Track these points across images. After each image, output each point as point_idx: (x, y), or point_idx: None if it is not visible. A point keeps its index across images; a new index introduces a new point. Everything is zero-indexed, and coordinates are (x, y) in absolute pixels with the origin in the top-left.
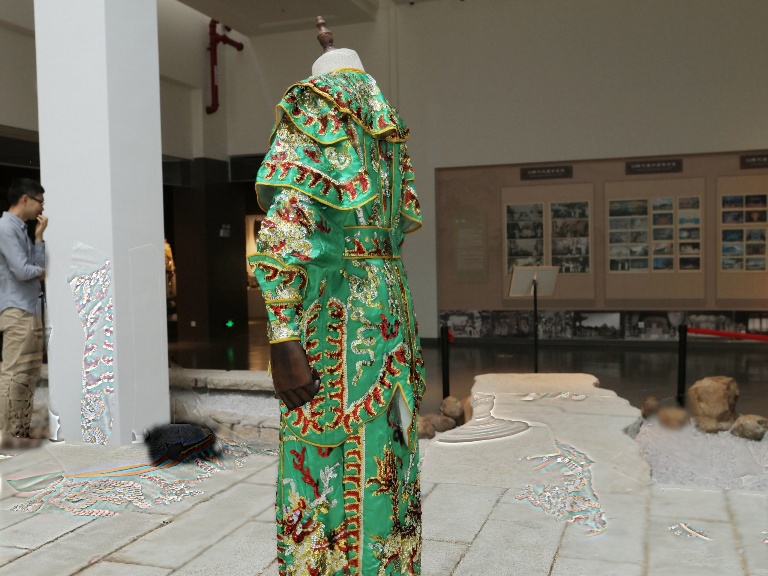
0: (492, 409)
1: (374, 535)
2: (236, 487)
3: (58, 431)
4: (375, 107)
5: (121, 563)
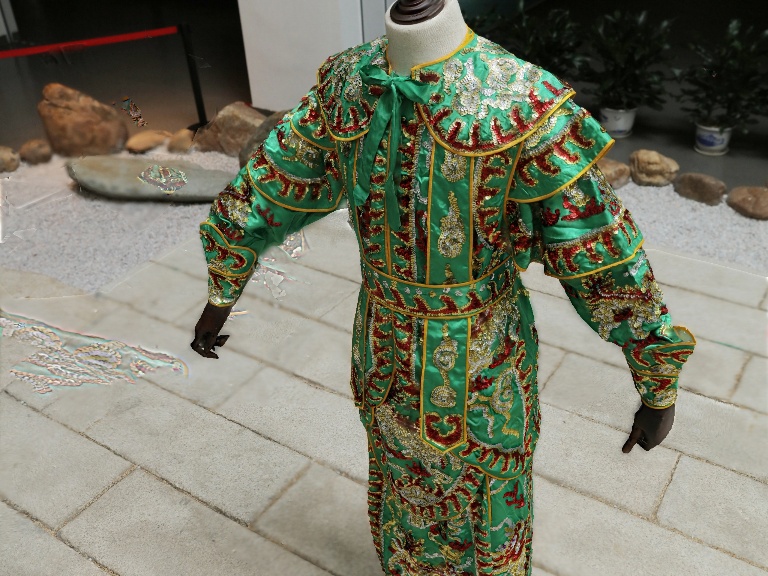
0: None
1: None
2: None
3: None
4: None
5: None
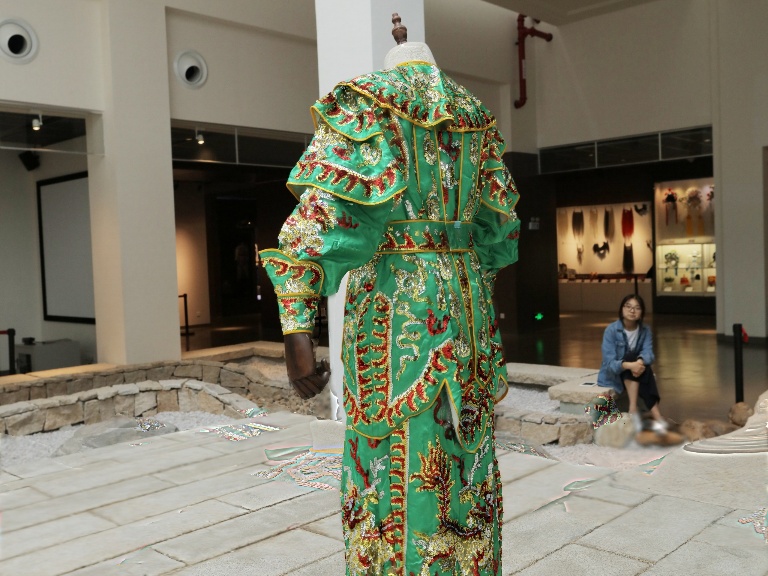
0: None
1: (417, 531)
2: None
3: (338, 410)
4: (434, 98)
5: (312, 532)
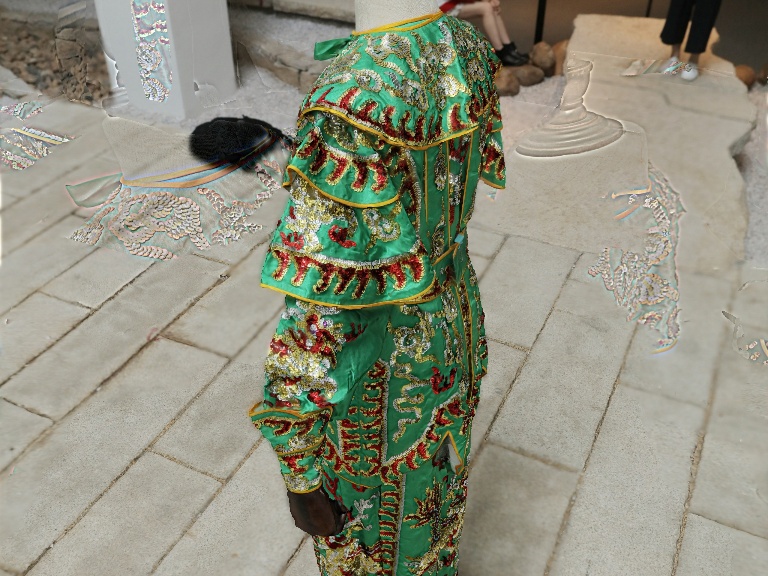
0: (586, 92)
1: (410, 556)
2: None
3: (117, 76)
4: (448, 89)
5: (179, 343)
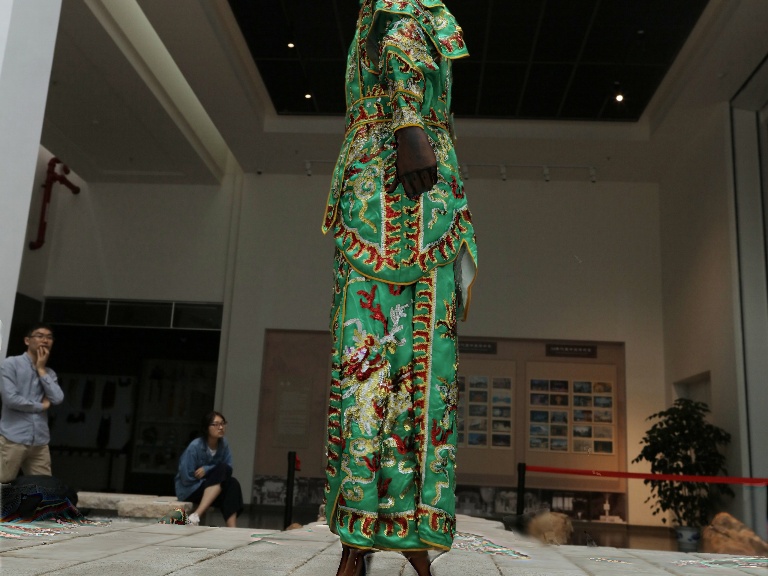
0: None
1: (441, 377)
2: (115, 532)
3: None
4: None
5: (13, 557)
